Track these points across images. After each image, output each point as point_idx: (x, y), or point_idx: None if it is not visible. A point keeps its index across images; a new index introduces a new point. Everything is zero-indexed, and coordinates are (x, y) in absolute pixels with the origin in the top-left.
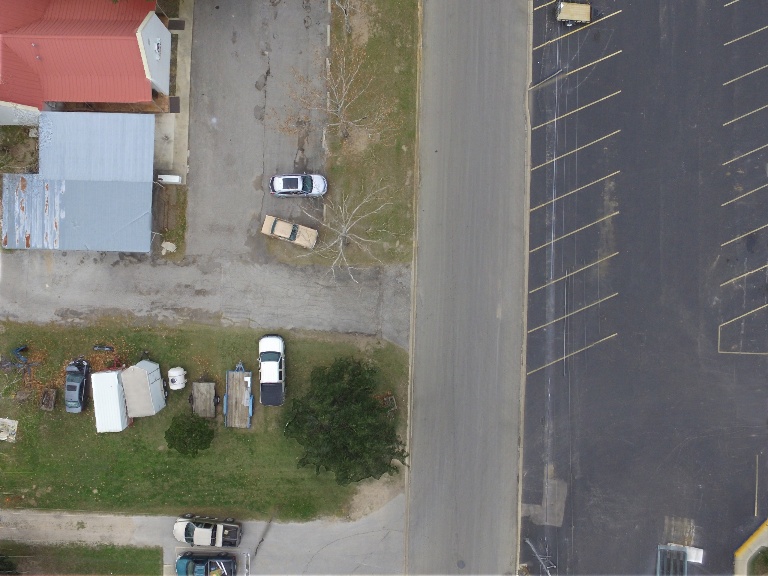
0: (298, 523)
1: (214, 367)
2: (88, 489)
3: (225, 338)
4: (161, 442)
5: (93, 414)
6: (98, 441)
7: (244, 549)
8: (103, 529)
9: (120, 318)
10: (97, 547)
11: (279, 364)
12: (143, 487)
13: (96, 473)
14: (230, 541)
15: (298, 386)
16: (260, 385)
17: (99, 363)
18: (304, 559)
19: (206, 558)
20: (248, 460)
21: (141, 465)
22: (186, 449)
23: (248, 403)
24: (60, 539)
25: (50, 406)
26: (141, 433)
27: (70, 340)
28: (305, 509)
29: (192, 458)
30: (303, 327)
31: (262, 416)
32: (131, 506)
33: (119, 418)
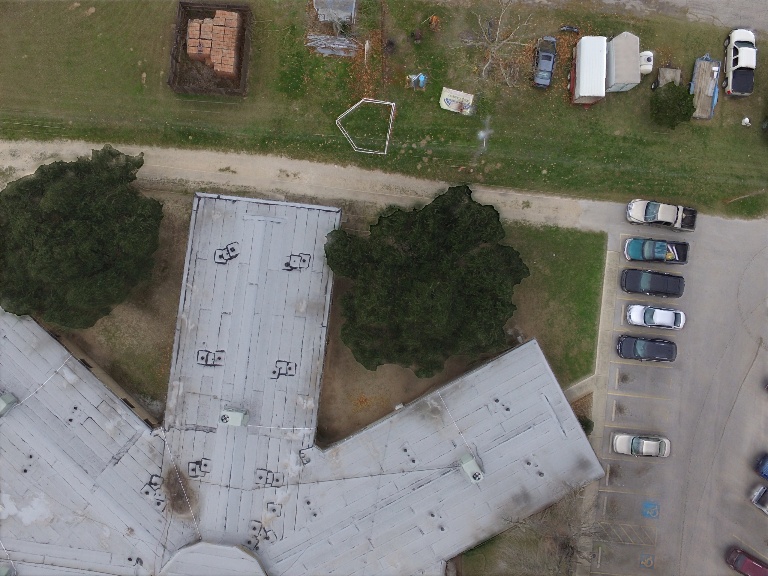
0: (744, 220)
1: (676, 59)
2: (537, 169)
3: (690, 32)
4: (618, 127)
5: (551, 94)
6: (554, 121)
7: (688, 241)
8: (549, 210)
9: (588, 4)
10: (541, 228)
11: (756, 51)
12: (593, 171)
13: (548, 153)
14: (684, 227)
15: (755, 86)
16: (732, 73)
17: (562, 45)
18: (746, 257)
19: (661, 240)
20: (701, 153)
21: (595, 148)
22: (680, 112)
23: (712, 93)
24: (504, 217)
25: (515, 79)
26: (598, 117)
27: (535, 20)
28: (752, 207)
29: (647, 145)
30: (763, 31)
31: (719, 111)
32: (579, 189)
33: (604, 83)
